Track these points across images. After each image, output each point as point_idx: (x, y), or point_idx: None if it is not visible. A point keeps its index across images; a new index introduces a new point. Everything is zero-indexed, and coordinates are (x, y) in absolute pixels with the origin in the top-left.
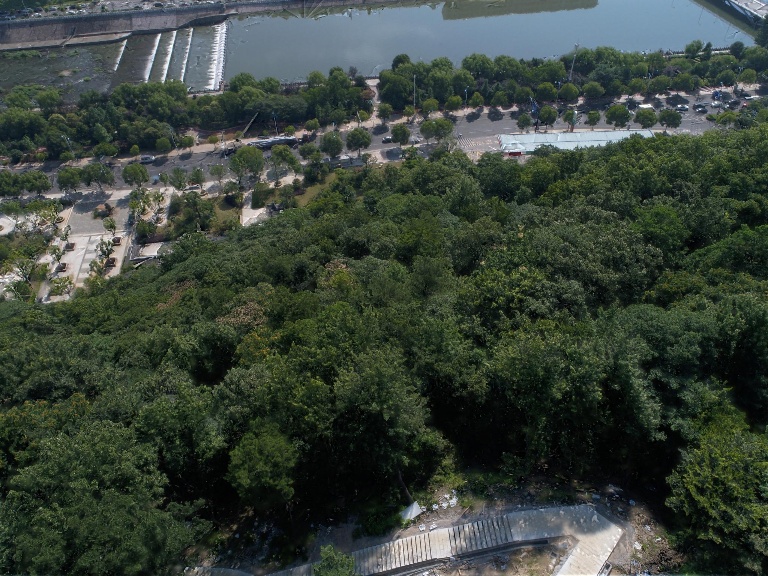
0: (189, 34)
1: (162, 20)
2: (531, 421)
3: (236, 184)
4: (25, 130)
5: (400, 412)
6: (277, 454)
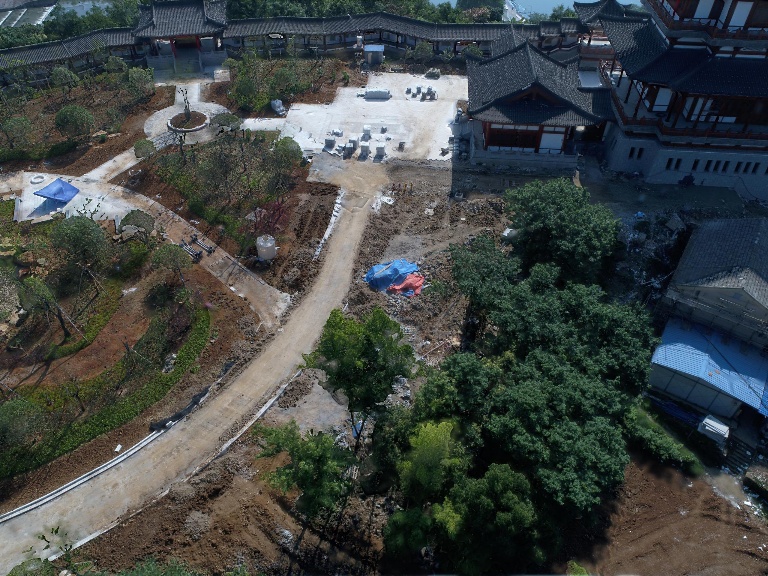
0: (21, 13)
1: (1, 2)
2: None
3: None
4: None
5: None
6: None
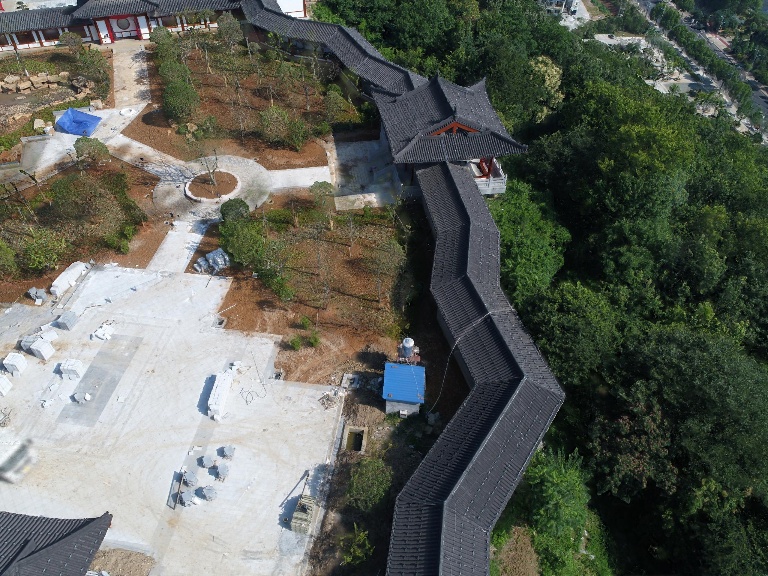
0: None
1: None
2: None
3: (761, 139)
4: (763, 43)
5: None
6: None
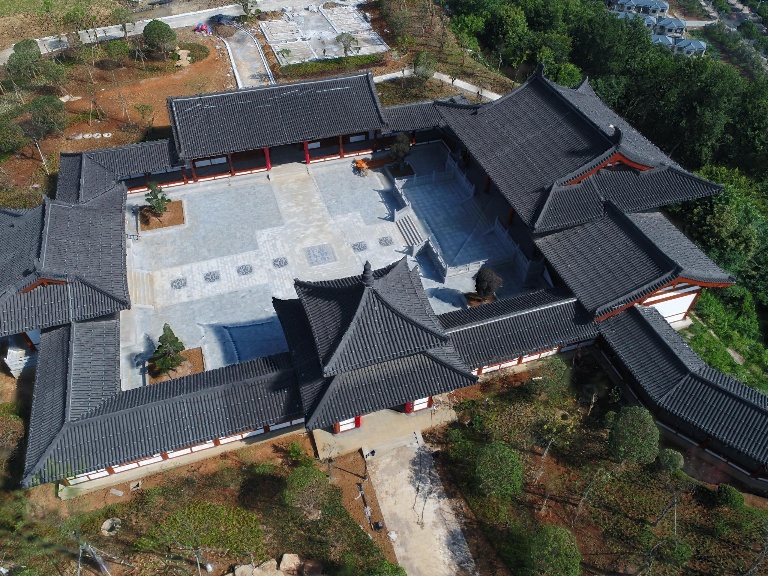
0: None
1: None
2: (735, 162)
3: None
4: None
5: (708, 100)
6: (663, 64)
